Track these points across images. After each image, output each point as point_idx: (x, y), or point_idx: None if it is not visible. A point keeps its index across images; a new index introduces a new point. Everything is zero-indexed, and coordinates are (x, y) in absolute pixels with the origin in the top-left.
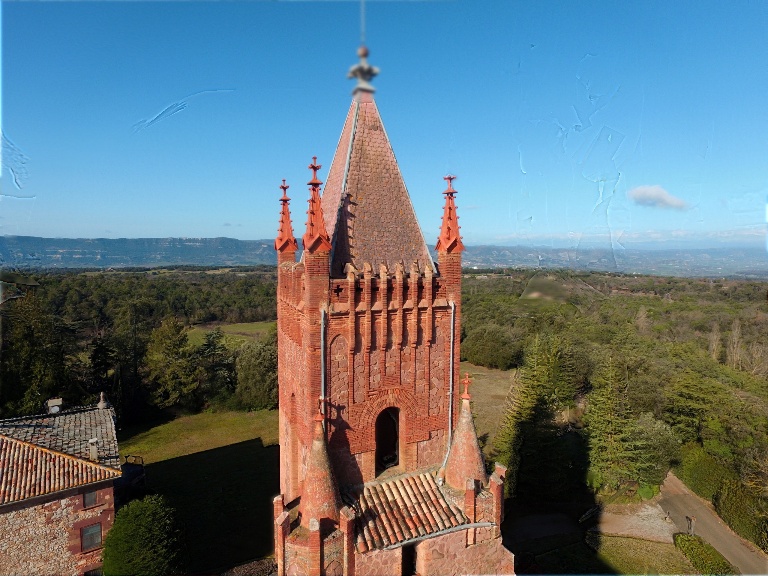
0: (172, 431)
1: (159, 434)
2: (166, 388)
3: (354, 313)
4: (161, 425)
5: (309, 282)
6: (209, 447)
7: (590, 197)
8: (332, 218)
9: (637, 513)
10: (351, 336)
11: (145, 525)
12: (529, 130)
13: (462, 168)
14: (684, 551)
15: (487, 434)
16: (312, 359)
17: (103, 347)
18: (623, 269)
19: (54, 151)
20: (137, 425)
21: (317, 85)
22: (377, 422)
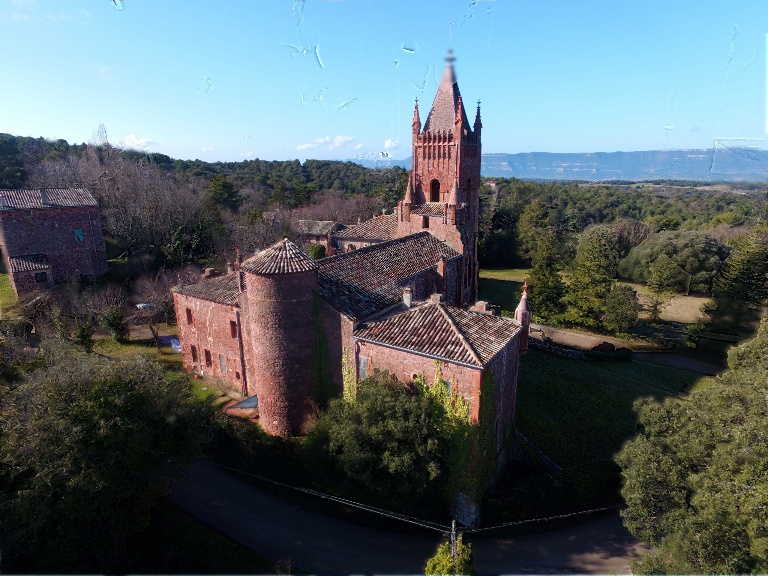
0: (523, 272)
1: (515, 272)
2: (527, 246)
3: (423, 146)
4: (521, 269)
5: None
6: None
7: None
8: None
9: None
10: (422, 153)
11: None
12: None
13: (747, 49)
14: None
15: None
16: None
17: (499, 214)
18: None
19: (329, 112)
20: (508, 266)
21: None
22: None
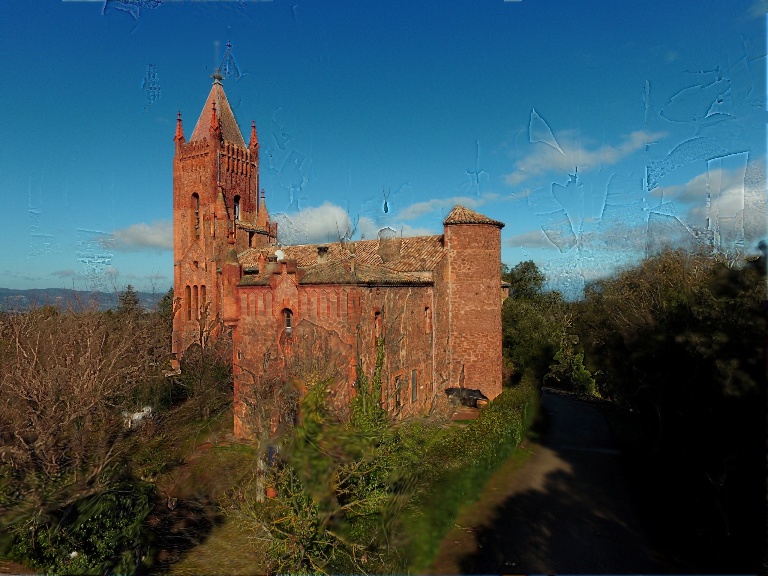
0: None
1: None
2: None
3: None
4: None
5: (214, 141)
6: None
7: (283, 209)
8: None
9: None
10: (227, 164)
11: None
12: None
13: None
14: None
15: None
16: (215, 168)
17: None
18: (308, 234)
19: None
20: None
21: (268, 77)
22: None
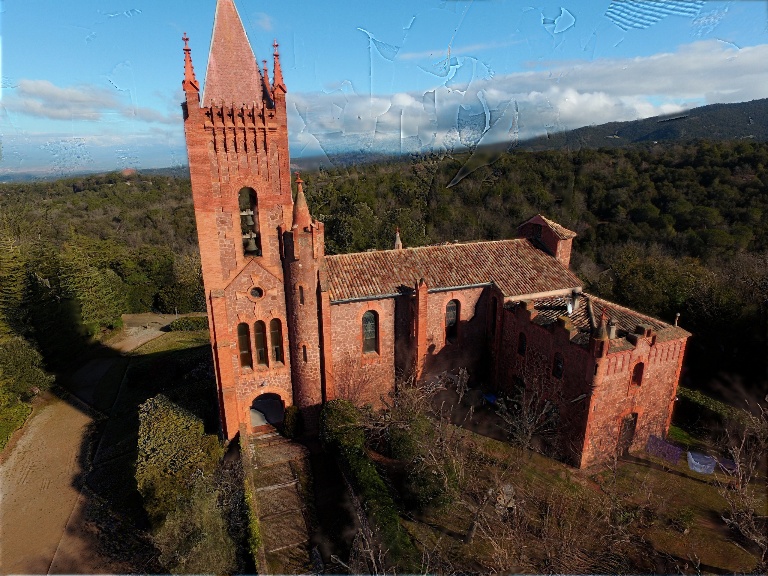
0: None
1: None
2: None
3: None
4: None
5: None
6: None
7: None
8: (252, 74)
9: (129, 335)
10: None
11: None
12: None
13: None
14: (180, 328)
15: None
16: None
17: None
18: None
19: None
20: None
21: None
22: None
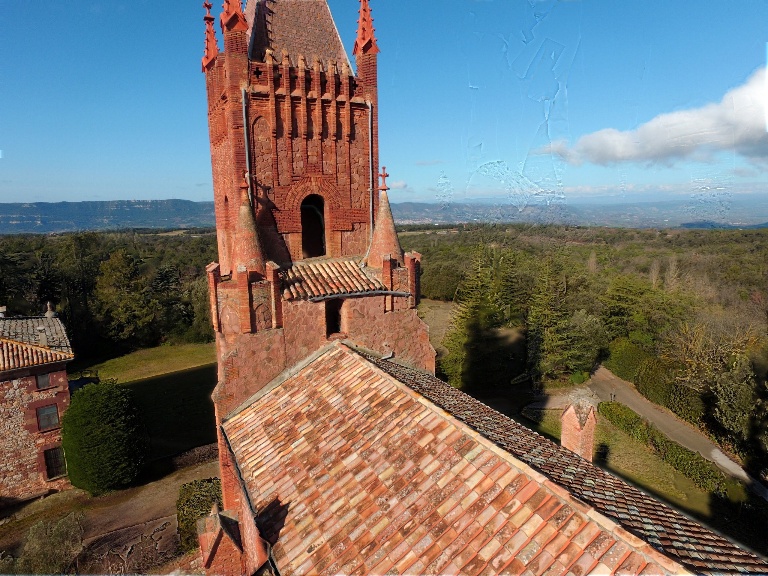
0: (129, 361)
1: (116, 364)
2: (120, 321)
3: (274, 95)
4: (117, 357)
5: (228, 59)
6: (168, 371)
7: None
8: (252, 16)
9: (568, 394)
10: (272, 118)
11: (101, 402)
12: (474, 43)
13: (408, 79)
14: (605, 414)
15: (439, 348)
16: (236, 136)
17: (48, 282)
18: (561, 178)
19: None
20: (92, 358)
21: None
22: (311, 243)
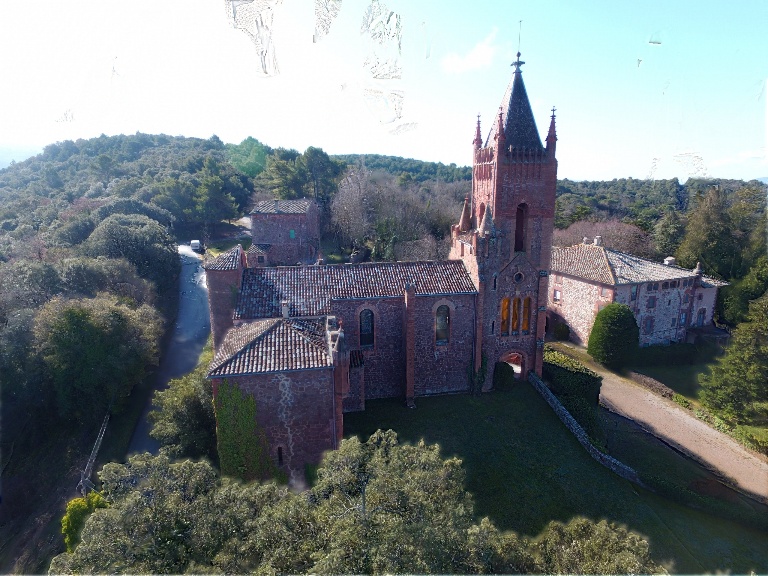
0: None
1: None
2: None
3: None
4: None
5: None
6: None
7: None
8: None
9: None
10: None
11: (606, 311)
12: None
13: None
14: None
15: None
16: None
17: None
18: None
19: None
20: None
21: None
22: None
